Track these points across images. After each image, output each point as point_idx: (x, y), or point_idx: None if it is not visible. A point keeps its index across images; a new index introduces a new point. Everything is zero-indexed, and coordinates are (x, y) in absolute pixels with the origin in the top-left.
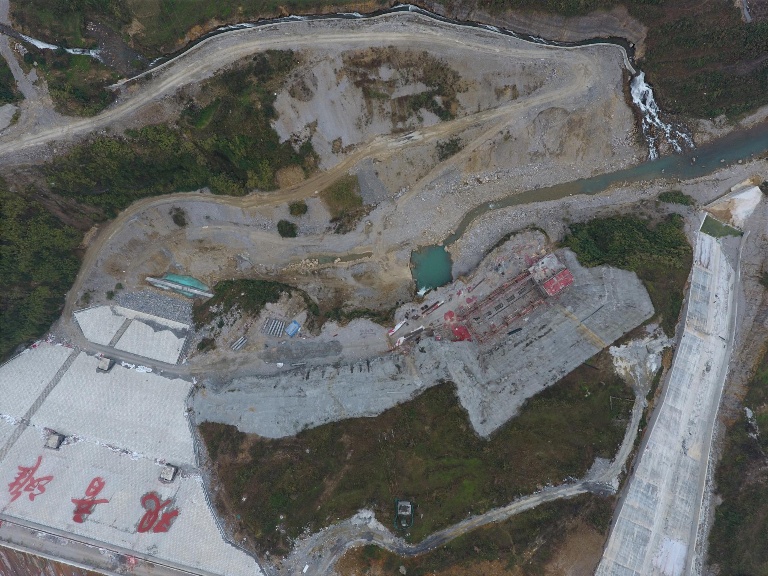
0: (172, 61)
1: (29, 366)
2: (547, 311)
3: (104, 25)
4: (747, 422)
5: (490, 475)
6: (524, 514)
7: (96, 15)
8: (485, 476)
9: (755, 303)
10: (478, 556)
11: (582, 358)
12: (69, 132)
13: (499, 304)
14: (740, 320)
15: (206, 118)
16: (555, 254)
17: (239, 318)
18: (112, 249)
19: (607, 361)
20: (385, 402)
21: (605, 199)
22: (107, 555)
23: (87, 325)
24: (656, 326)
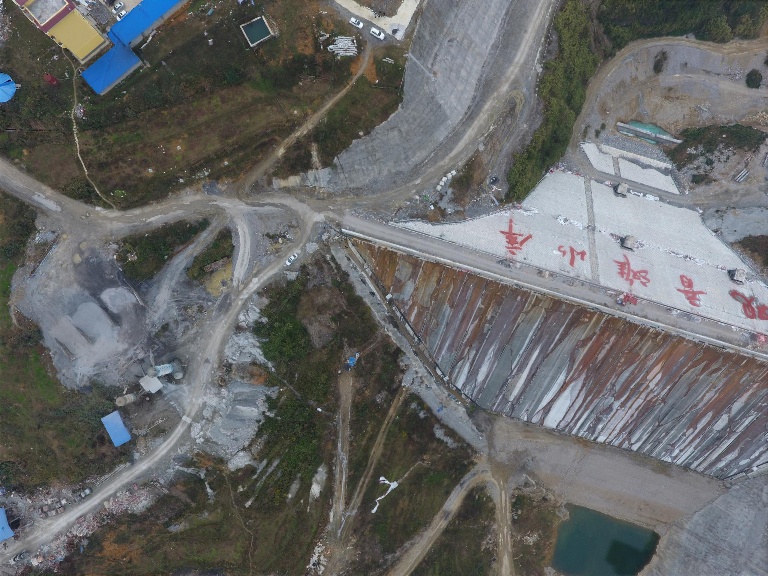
0: None
1: (560, 186)
2: None
3: None
4: None
5: None
6: None
7: None
8: None
9: None
10: None
11: None
12: None
13: None
14: None
15: None
16: None
17: (733, 154)
18: (608, 87)
19: None
20: None
21: None
22: (739, 333)
23: (590, 156)
24: None
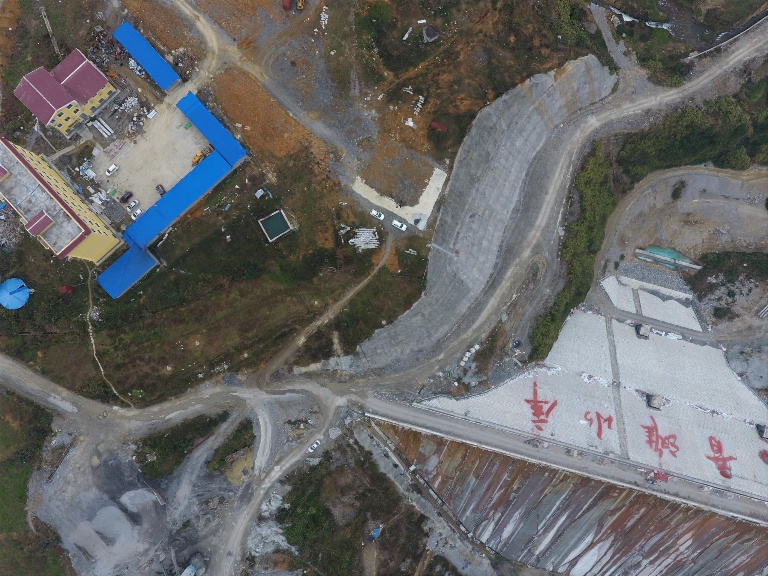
0: (738, 36)
1: (581, 332)
2: None
3: (674, 0)
4: None
5: None
6: None
7: None
8: None
9: None
10: None
11: None
12: (661, 101)
13: None
14: None
15: (758, 91)
16: None
17: (755, 287)
18: (627, 220)
19: None
20: None
21: None
22: None
23: (611, 293)
24: None
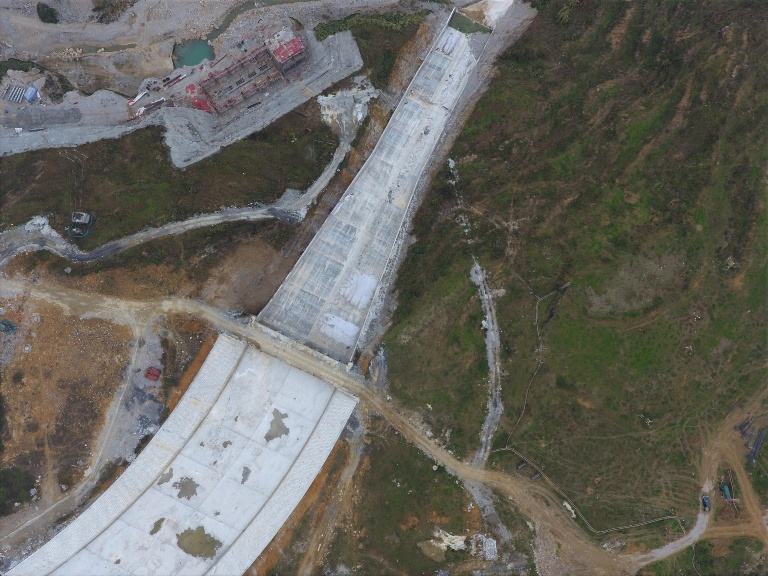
0: None
1: None
2: (286, 87)
3: None
4: (449, 171)
5: (176, 197)
6: (200, 228)
7: None
8: (171, 197)
9: (482, 79)
10: (145, 260)
11: (291, 107)
12: None
13: (240, 79)
14: (465, 93)
15: None
16: (297, 34)
17: None
18: None
19: (315, 109)
20: (90, 138)
21: (367, 1)
22: None
23: None
24: (364, 77)
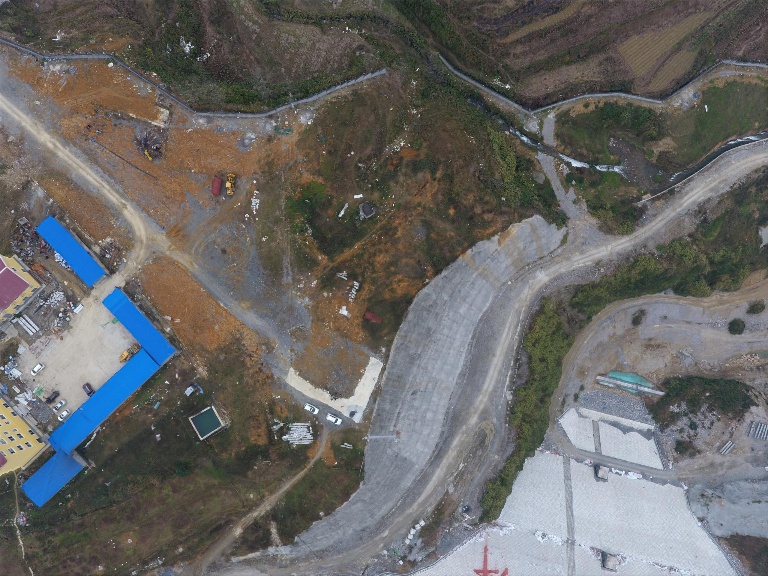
0: (692, 176)
1: (537, 478)
2: None
3: (625, 141)
4: None
5: None
6: None
7: (618, 132)
8: None
9: None
10: None
11: None
12: (612, 251)
13: None
14: None
15: (714, 229)
16: None
17: (717, 421)
18: (585, 353)
19: None
20: None
21: None
22: None
23: (569, 431)
24: None
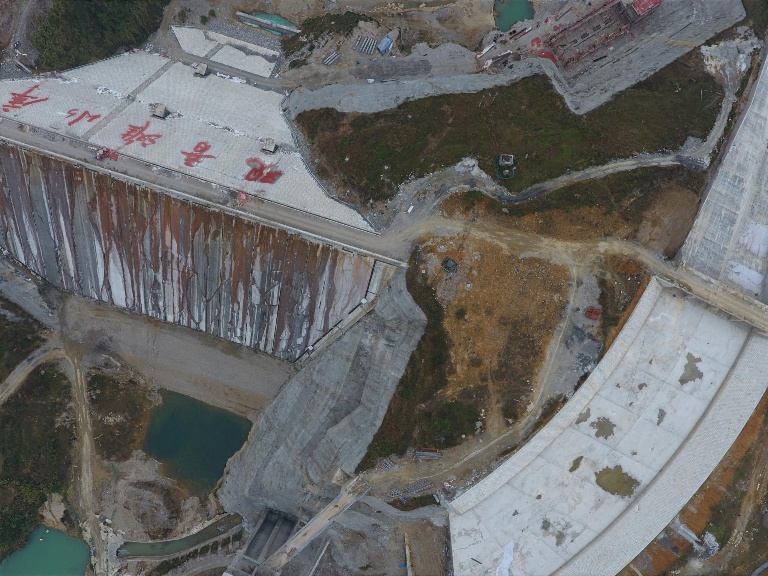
0: None
1: (130, 63)
2: (632, 40)
3: None
4: None
5: (587, 142)
6: (621, 172)
7: None
8: (582, 143)
9: None
10: (578, 202)
11: (674, 57)
12: None
13: (585, 33)
14: None
15: None
16: None
17: (331, 39)
18: None
19: (698, 60)
20: (483, 85)
21: None
22: (219, 190)
23: (183, 39)
24: (747, 28)
